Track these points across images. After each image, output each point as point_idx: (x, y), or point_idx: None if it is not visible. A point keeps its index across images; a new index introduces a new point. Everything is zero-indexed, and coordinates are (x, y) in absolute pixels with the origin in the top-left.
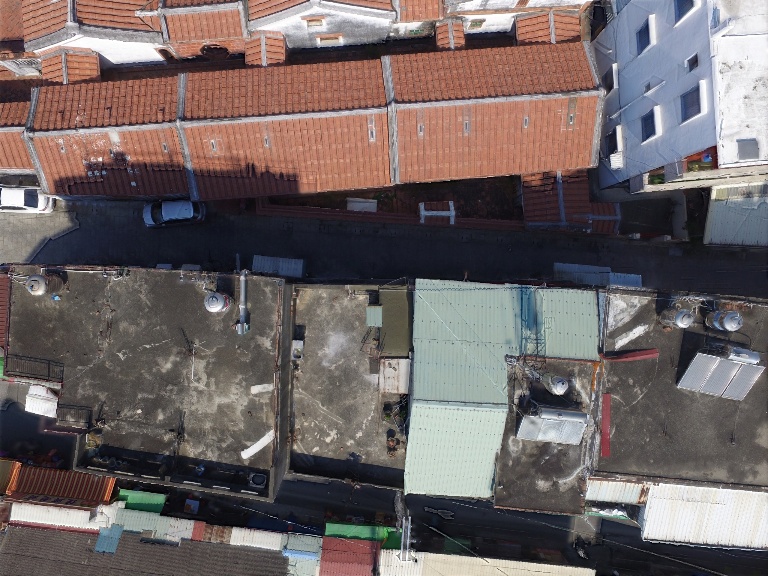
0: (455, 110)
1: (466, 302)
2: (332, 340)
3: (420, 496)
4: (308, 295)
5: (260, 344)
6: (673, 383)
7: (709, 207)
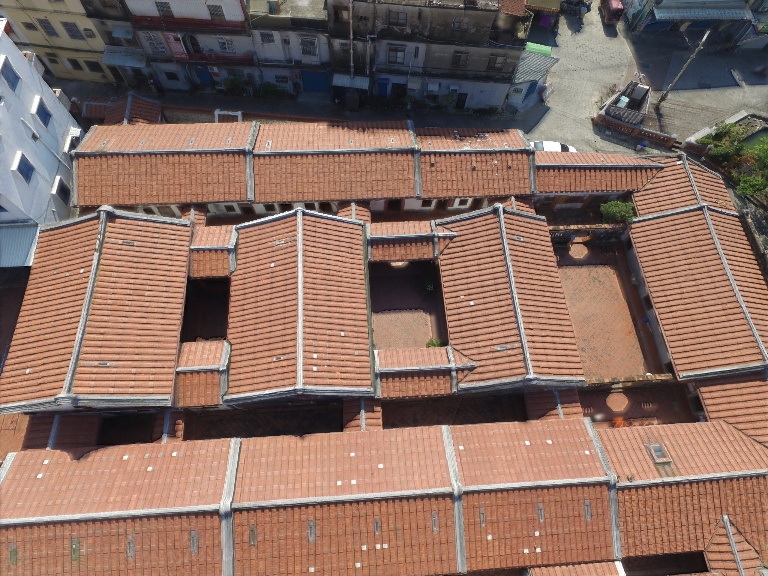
0: (198, 148)
1: None
2: (306, 3)
3: None
4: None
5: None
6: None
7: None
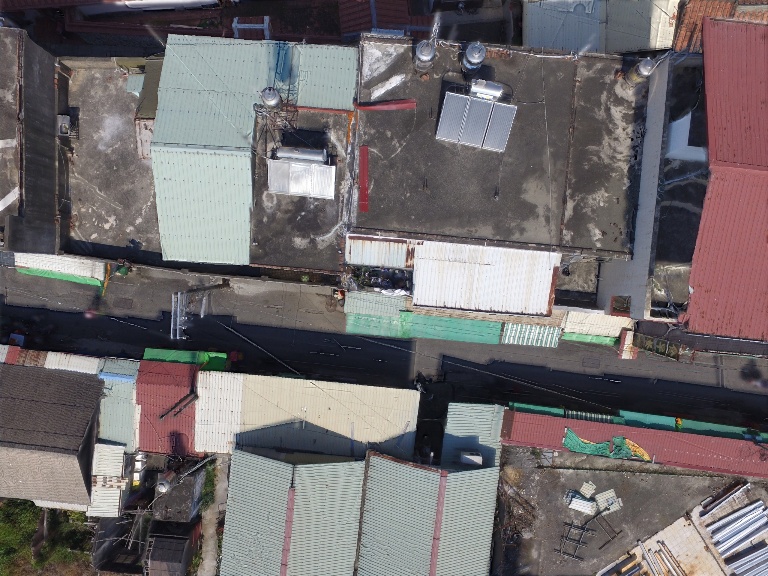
0: None
1: (219, 56)
2: (107, 122)
3: (255, 332)
4: (81, 75)
5: (1, 97)
6: (432, 135)
7: (523, 9)
